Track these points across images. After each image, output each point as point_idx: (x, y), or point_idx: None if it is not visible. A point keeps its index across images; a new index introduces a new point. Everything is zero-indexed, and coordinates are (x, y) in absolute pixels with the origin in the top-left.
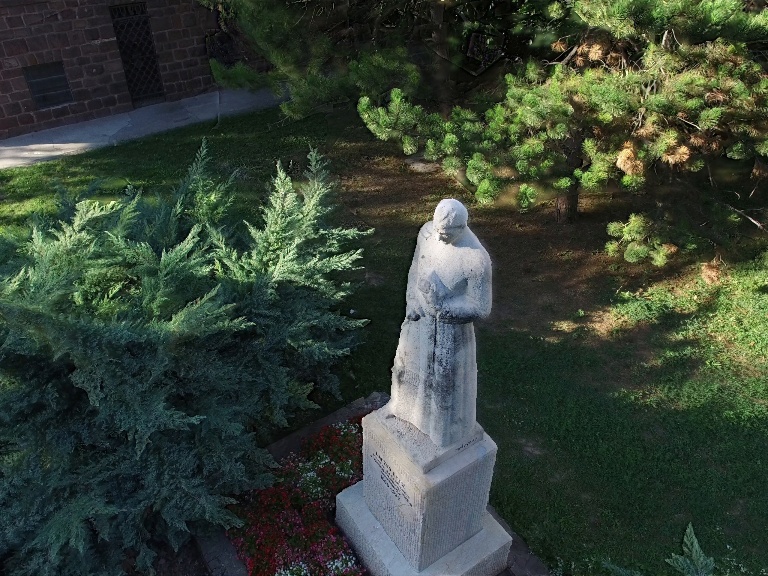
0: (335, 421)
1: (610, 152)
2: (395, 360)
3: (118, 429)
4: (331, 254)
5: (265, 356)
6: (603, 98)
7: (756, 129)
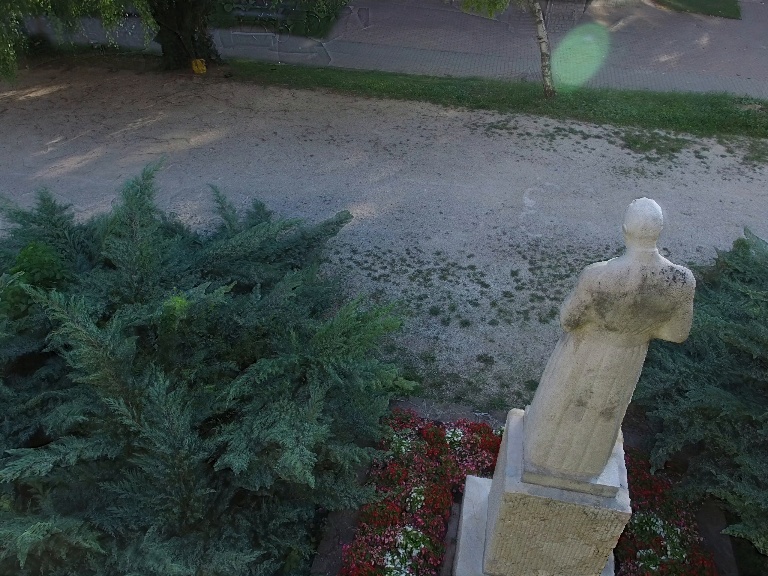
0: None
1: None
2: None
3: (760, 367)
4: None
5: None
6: None
7: None
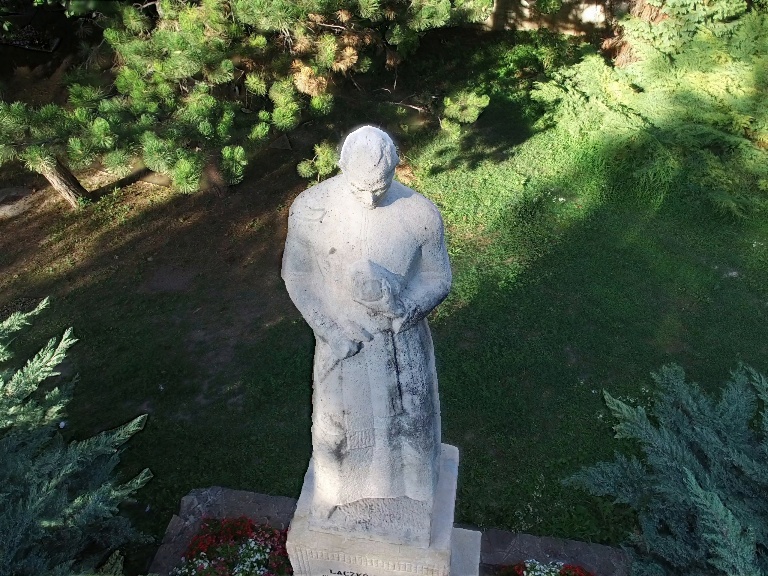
0: (164, 573)
1: (283, 80)
2: (321, 433)
3: None
4: (2, 367)
5: (14, 573)
6: (262, 11)
7: (393, 11)
